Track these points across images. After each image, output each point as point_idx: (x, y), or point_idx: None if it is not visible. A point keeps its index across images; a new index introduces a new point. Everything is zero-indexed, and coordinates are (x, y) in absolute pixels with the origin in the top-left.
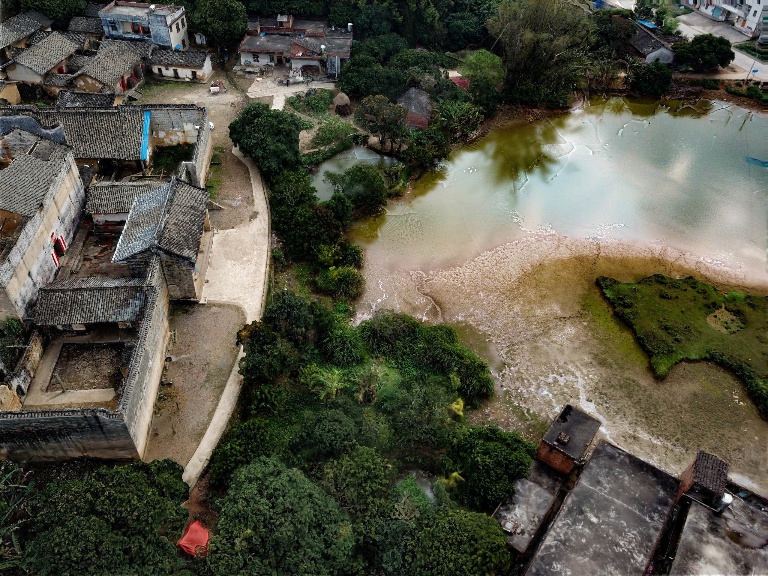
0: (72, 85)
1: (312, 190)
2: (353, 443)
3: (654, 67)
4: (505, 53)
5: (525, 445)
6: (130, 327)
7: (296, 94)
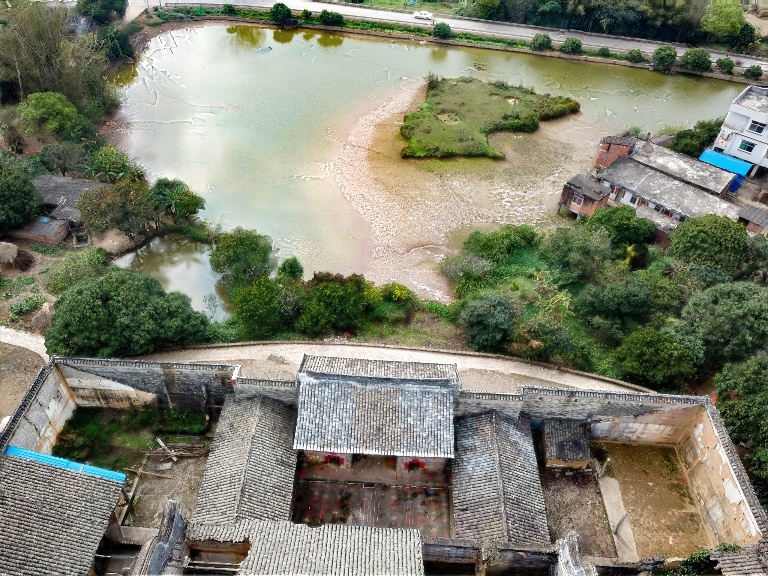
0: None
1: None
2: None
3: None
4: None
5: None
6: None
7: None
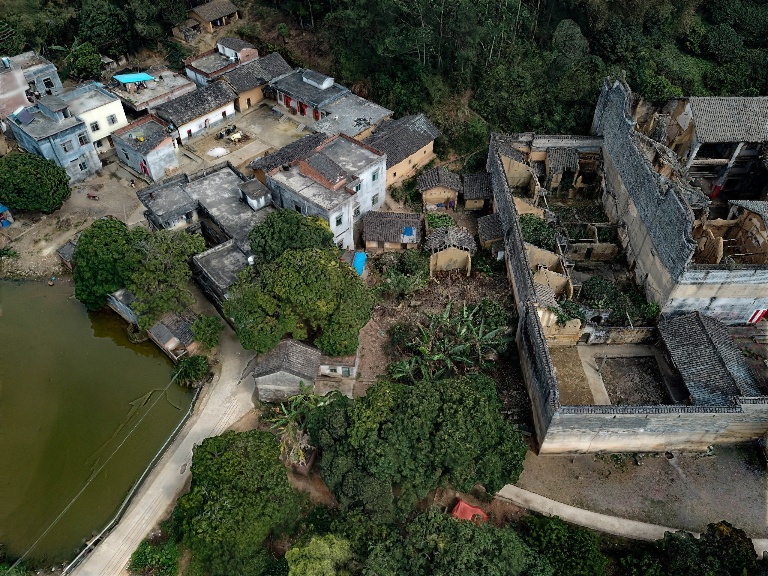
0: None
1: None
2: None
3: None
4: None
5: None
6: None
7: None
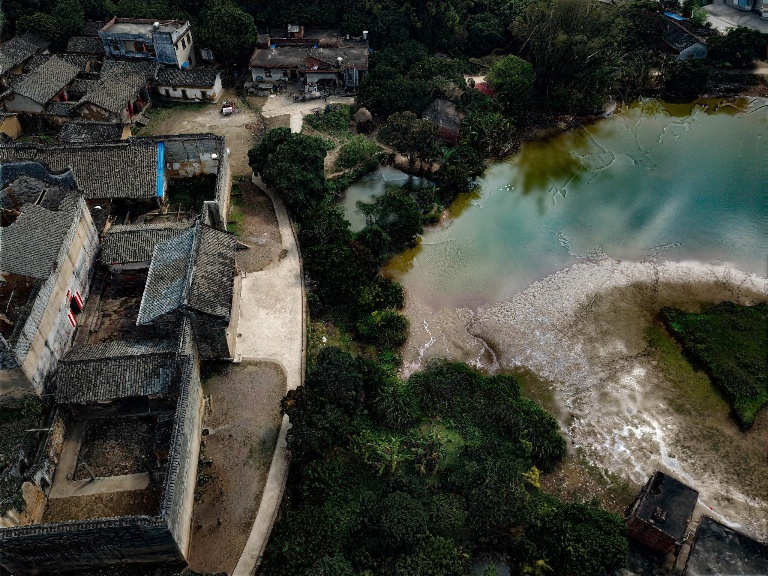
0: (76, 114)
1: (345, 224)
2: (426, 535)
3: (691, 64)
4: (530, 55)
5: (617, 524)
6: (161, 397)
7: (314, 111)
